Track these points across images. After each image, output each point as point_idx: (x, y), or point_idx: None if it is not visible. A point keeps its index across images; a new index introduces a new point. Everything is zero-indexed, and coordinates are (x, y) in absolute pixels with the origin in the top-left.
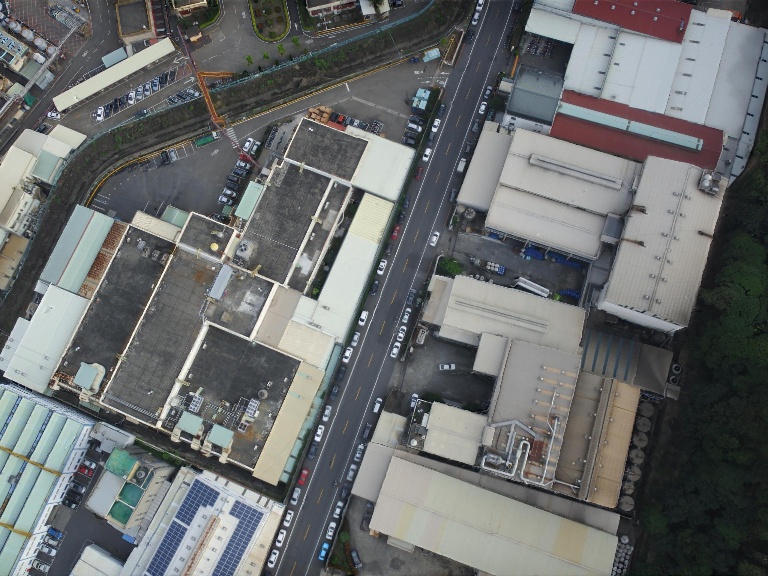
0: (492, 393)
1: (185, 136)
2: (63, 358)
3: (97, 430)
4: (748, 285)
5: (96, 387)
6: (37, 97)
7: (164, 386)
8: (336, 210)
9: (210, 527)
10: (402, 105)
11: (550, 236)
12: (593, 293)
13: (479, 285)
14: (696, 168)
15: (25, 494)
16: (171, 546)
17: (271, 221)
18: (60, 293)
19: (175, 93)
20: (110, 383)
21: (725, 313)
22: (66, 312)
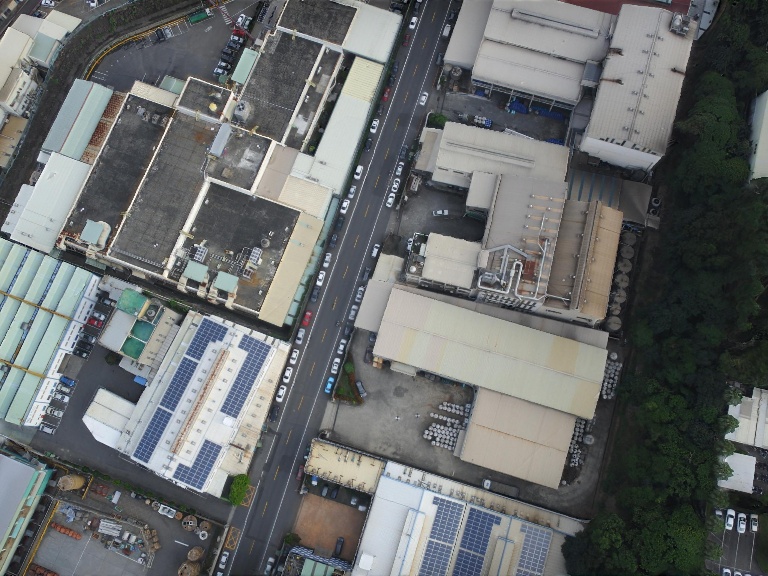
0: (484, 230)
1: (179, 15)
2: (68, 219)
3: (105, 281)
4: (719, 113)
5: (102, 243)
6: None
7: (169, 238)
8: (328, 74)
9: (220, 359)
10: None
11: (533, 84)
12: (576, 136)
13: (468, 129)
14: (667, 12)
15: (38, 339)
16: (183, 380)
17: (266, 85)
18: (63, 159)
19: None
20: (116, 238)
21: (699, 139)
22: (69, 177)
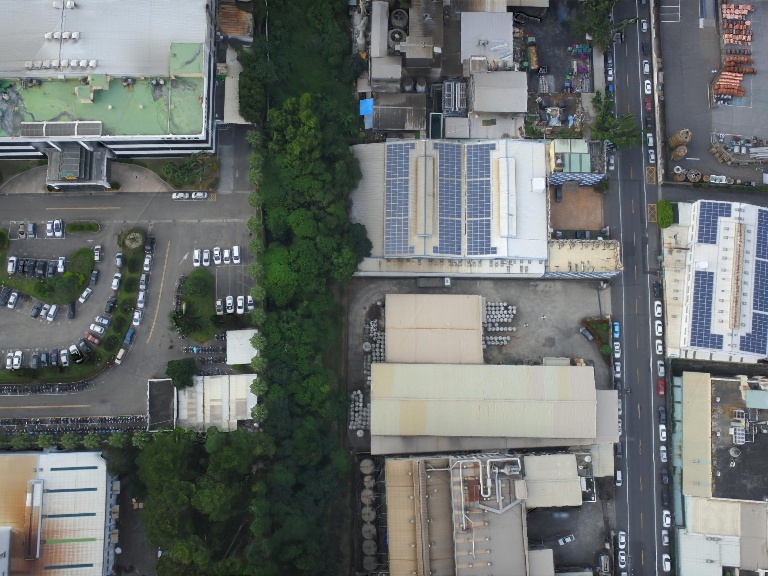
0: None
1: None
2: None
3: None
4: None
5: None
6: None
7: None
8: None
9: (736, 319)
10: None
11: None
12: None
13: None
14: None
15: None
16: (760, 290)
17: None
18: None
19: None
20: None
21: None
22: None
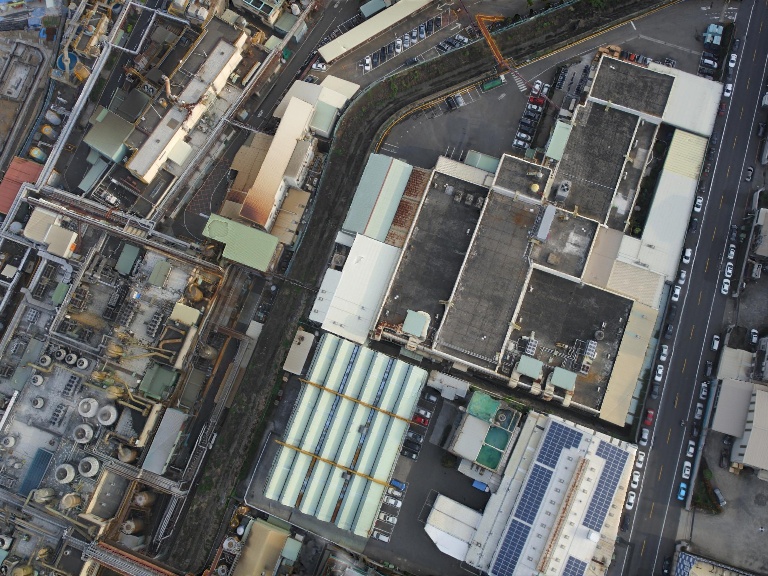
0: None
1: (468, 81)
2: (383, 307)
3: (435, 377)
4: None
5: (424, 335)
6: (292, 50)
7: (497, 331)
8: (645, 148)
9: (580, 468)
10: (693, 42)
11: None
12: None
13: None
14: None
15: (377, 443)
16: (538, 490)
17: (581, 161)
18: (369, 242)
19: (442, 40)
20: (440, 330)
21: None
22: (377, 261)
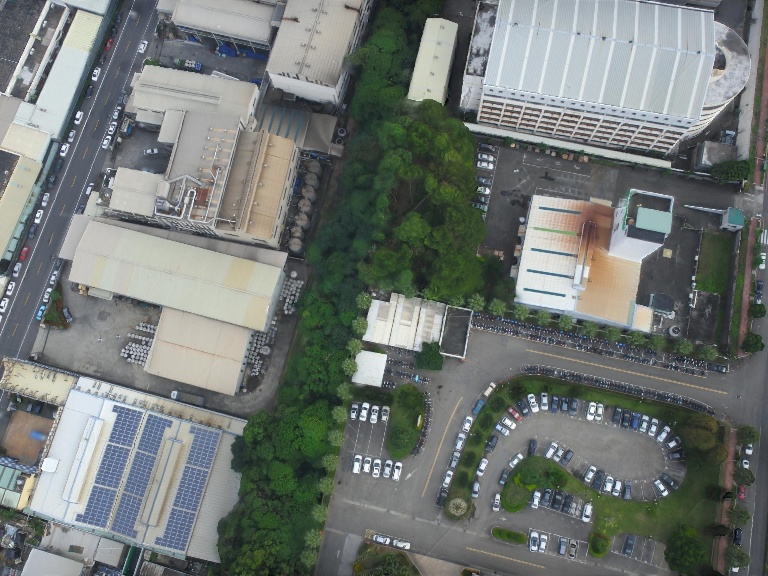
0: None
1: None
2: None
3: None
4: (381, 44)
5: None
6: None
7: None
8: (54, 28)
9: None
10: None
11: (229, 27)
12: None
13: (165, 71)
14: None
15: None
16: None
17: None
18: None
19: None
20: None
21: (363, 70)
22: None
